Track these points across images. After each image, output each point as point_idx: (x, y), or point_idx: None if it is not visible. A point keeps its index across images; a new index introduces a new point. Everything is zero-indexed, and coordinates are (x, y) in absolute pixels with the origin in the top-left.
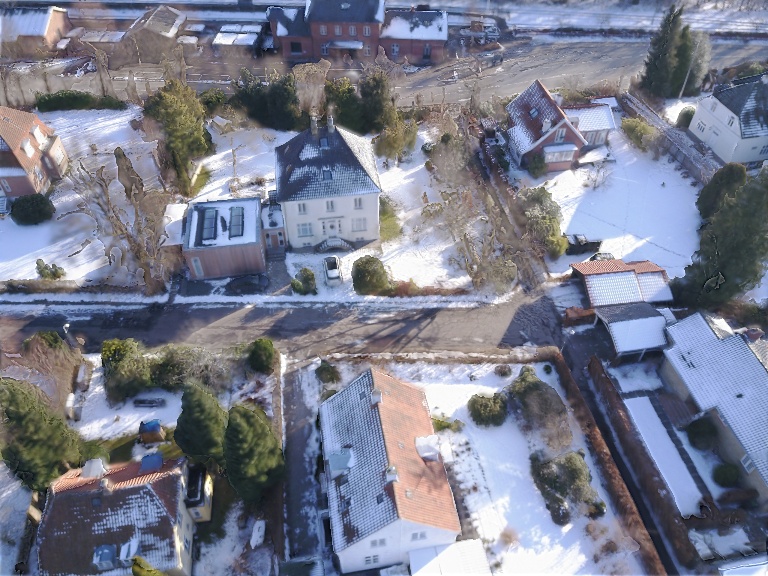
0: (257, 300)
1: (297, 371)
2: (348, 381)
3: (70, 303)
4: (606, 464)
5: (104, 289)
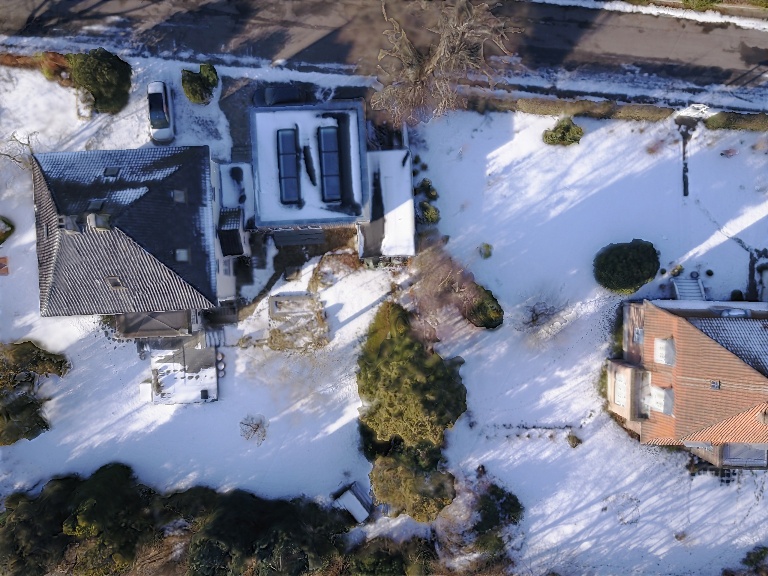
0: (270, 71)
1: None
2: None
3: (524, 89)
4: None
5: (483, 106)
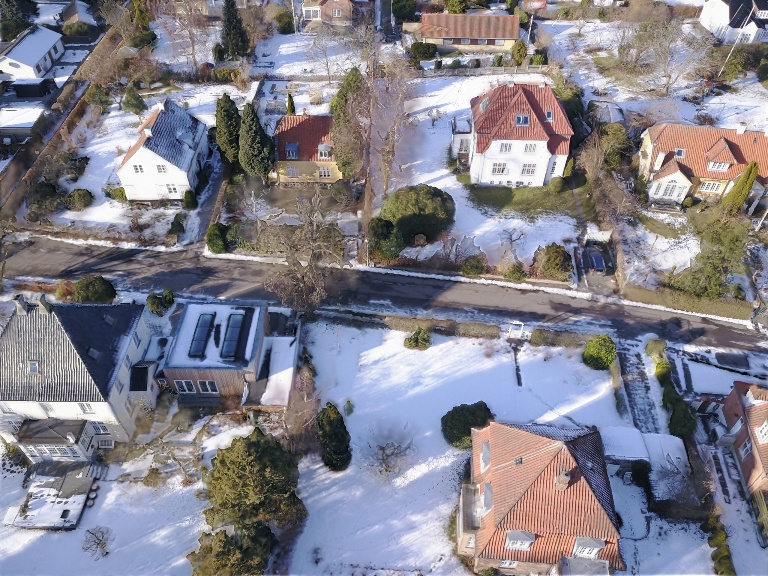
0: None
1: (198, 241)
2: (163, 230)
3: None
4: (37, 165)
5: (360, 325)
